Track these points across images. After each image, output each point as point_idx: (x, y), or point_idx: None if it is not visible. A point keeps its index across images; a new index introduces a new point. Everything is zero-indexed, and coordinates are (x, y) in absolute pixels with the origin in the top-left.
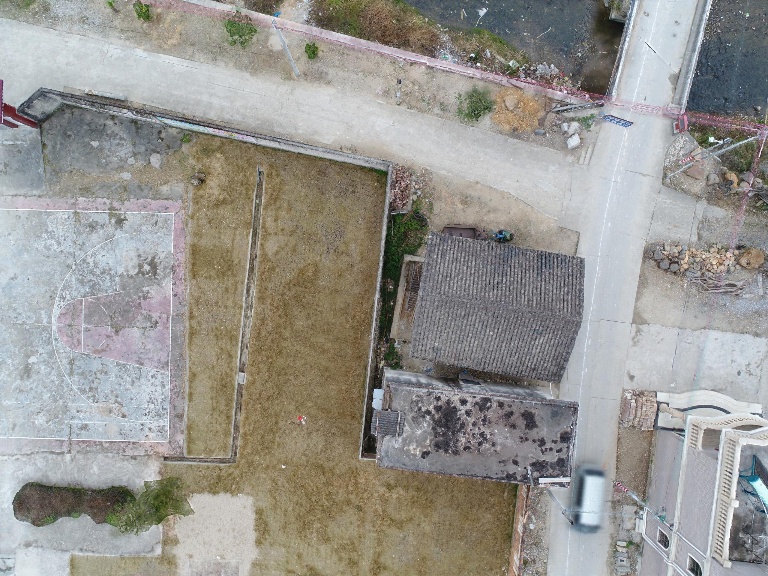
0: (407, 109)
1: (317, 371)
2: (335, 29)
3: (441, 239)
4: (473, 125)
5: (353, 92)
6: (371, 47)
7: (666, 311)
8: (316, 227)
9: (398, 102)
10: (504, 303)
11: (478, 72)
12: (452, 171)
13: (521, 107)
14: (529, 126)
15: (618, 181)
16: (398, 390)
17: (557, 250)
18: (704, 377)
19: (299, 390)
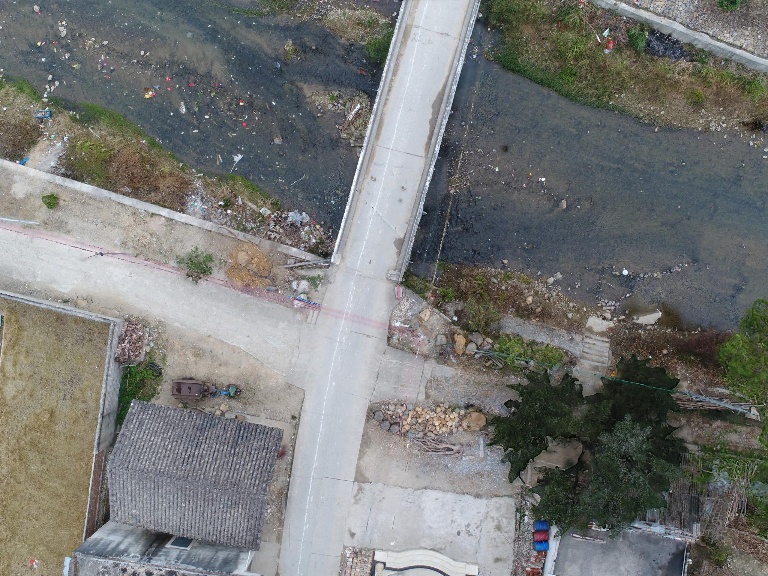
0: (144, 261)
1: (50, 515)
2: (84, 175)
3: (142, 407)
4: (208, 279)
5: (92, 242)
6: (112, 197)
7: (388, 470)
8: (53, 373)
9: (134, 254)
10: (191, 478)
11: (216, 226)
12: (185, 324)
13: (254, 263)
14: (261, 282)
15: (343, 341)
16: (85, 561)
17: (285, 406)
18: (424, 536)
19: (32, 534)
